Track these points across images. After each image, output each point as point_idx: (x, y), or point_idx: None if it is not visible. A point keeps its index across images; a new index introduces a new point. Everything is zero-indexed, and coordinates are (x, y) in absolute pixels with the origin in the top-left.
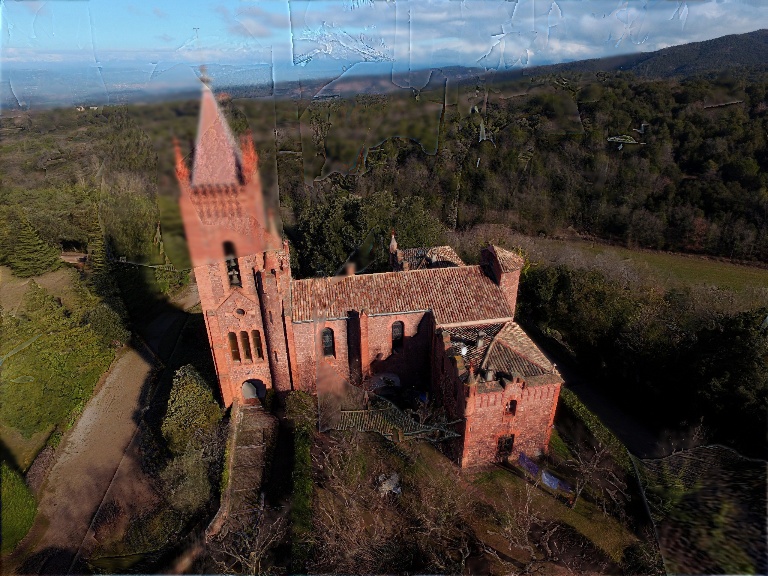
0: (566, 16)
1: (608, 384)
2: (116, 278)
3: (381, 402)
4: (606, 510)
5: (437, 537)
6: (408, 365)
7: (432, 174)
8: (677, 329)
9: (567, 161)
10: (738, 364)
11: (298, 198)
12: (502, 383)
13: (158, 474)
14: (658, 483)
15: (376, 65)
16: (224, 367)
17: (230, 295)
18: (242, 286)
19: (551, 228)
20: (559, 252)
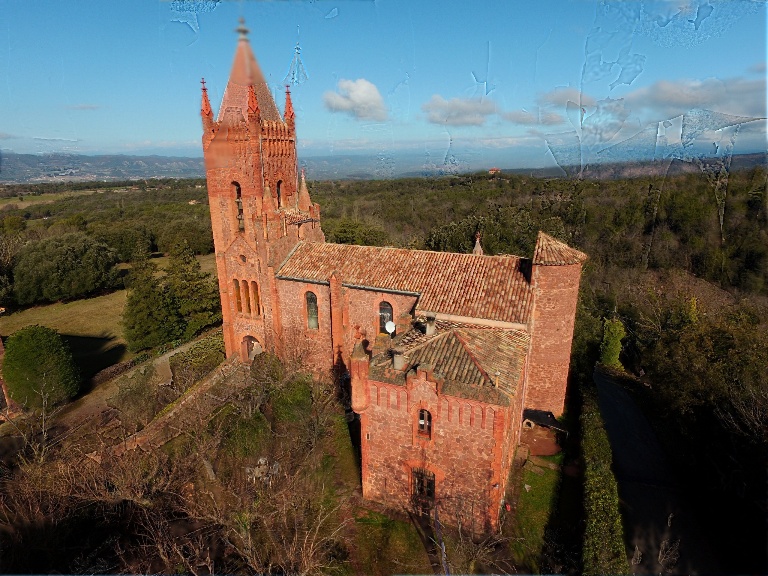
0: None
1: (722, 504)
2: None
3: None
4: None
5: (243, 547)
6: None
7: (633, 219)
8: None
9: None
10: None
11: None
12: None
13: None
14: None
15: None
16: (227, 314)
17: (235, 239)
18: (245, 231)
19: None
20: None
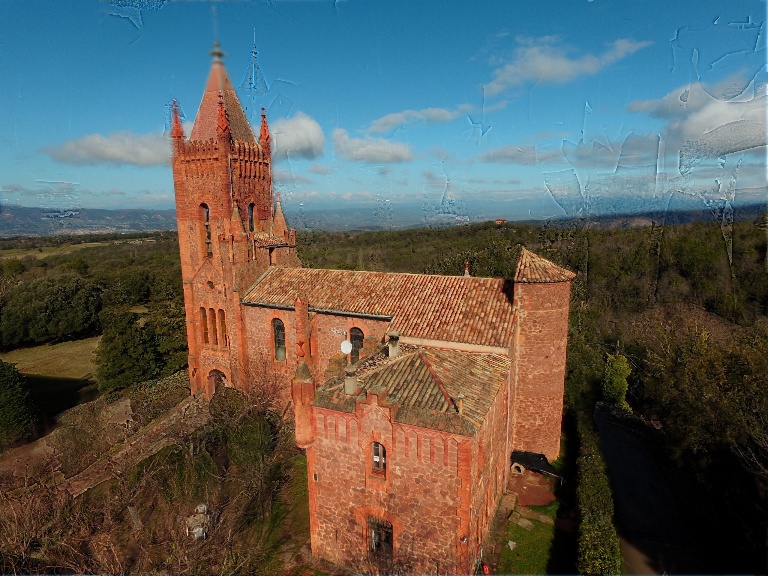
0: None
1: (752, 569)
2: None
3: None
4: None
5: None
6: None
7: (637, 258)
8: None
9: None
10: None
11: None
12: None
13: None
14: None
15: None
16: (193, 346)
17: (203, 264)
18: (213, 255)
19: None
20: None
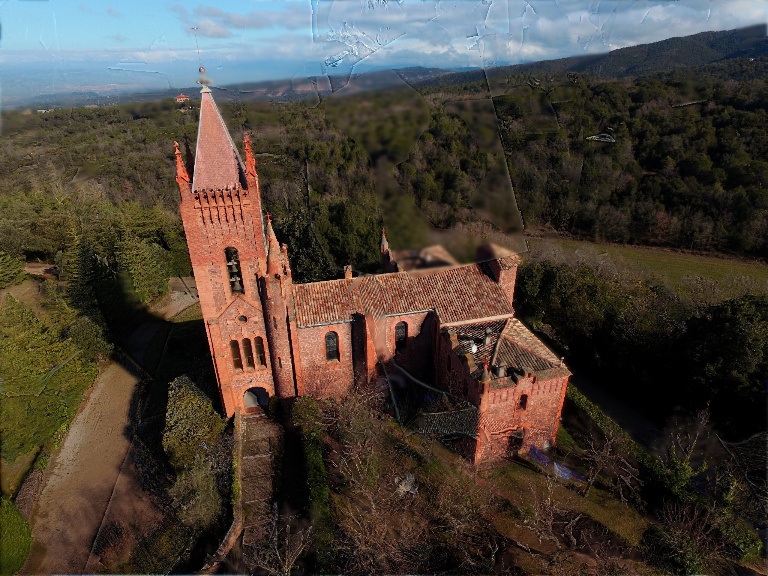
0: (541, 19)
1: (602, 375)
2: (93, 289)
3: (461, 403)
4: (617, 496)
5: (460, 534)
6: (411, 365)
7: None
8: (669, 319)
9: (544, 160)
10: (729, 349)
11: (277, 201)
12: (514, 378)
13: (160, 491)
14: (756, 466)
15: None
16: (226, 376)
17: (232, 302)
18: (245, 292)
19: (529, 225)
20: (540, 248)
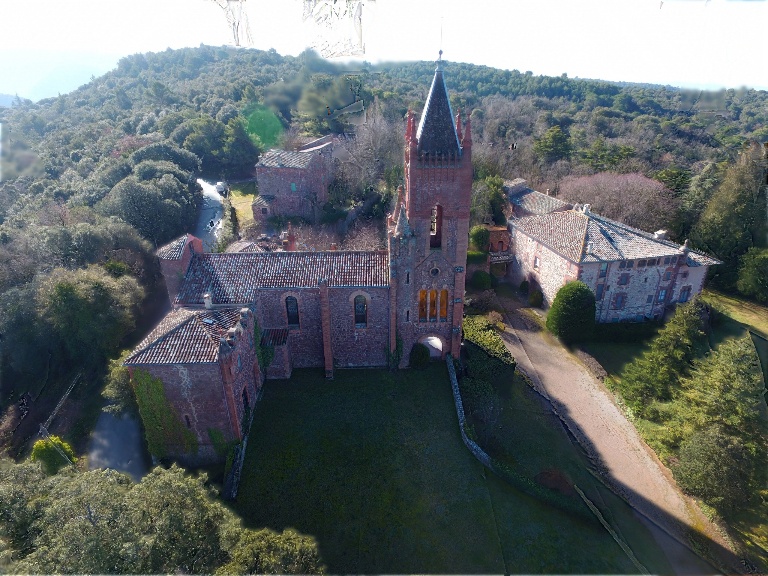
0: None
1: None
2: None
3: None
4: None
5: None
6: None
7: None
8: None
9: None
10: None
11: None
12: None
13: None
14: None
15: (320, 59)
16: None
17: None
18: None
19: None
20: None
